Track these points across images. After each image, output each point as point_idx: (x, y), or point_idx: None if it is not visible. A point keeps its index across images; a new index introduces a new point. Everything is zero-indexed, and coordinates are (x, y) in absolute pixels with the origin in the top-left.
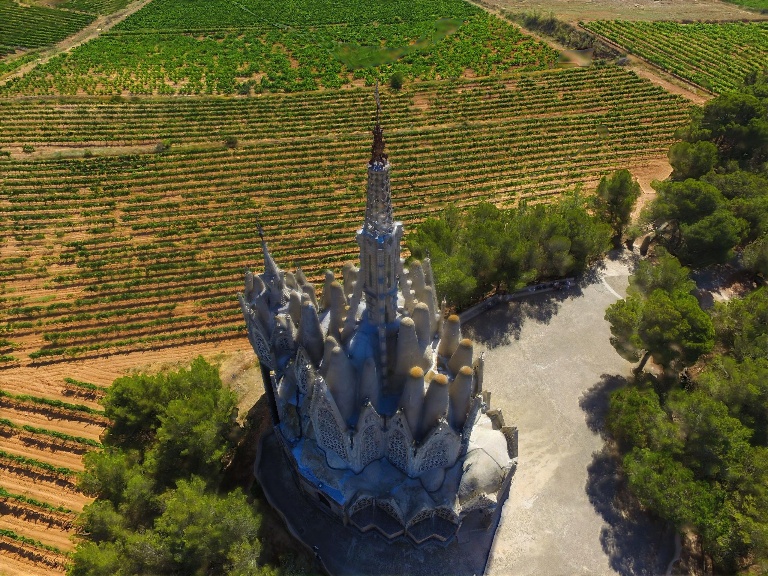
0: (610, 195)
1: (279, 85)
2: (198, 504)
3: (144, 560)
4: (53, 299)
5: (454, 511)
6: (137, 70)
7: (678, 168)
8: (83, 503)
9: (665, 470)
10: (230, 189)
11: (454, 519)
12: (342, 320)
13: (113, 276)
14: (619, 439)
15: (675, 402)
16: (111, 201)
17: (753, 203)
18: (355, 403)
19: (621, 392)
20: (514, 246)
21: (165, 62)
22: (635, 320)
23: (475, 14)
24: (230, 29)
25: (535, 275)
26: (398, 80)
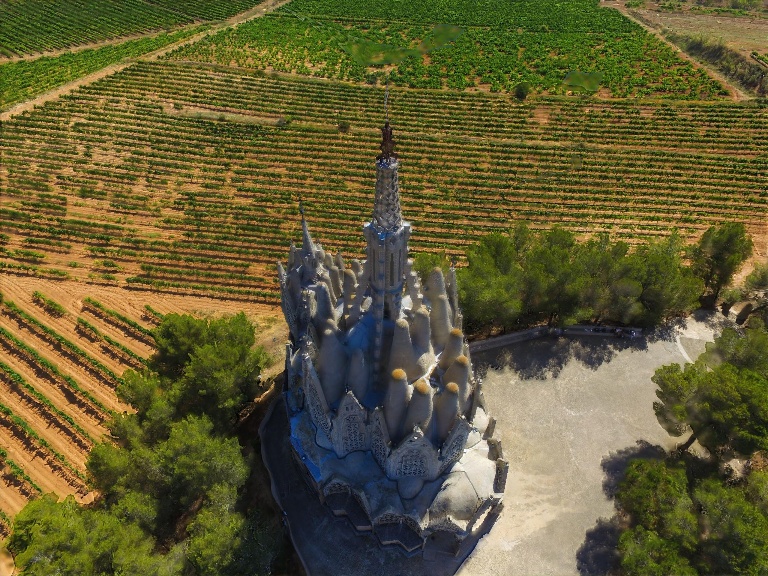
0: (715, 249)
1: (406, 79)
2: (196, 439)
3: (148, 474)
4: (158, 237)
5: (419, 524)
6: (284, 49)
7: None
8: (129, 413)
9: (665, 561)
10: (330, 170)
11: (420, 532)
12: (348, 307)
13: (209, 228)
14: None
15: (705, 492)
16: (227, 162)
17: None
18: (342, 389)
19: (645, 463)
20: (573, 279)
21: (310, 45)
22: (685, 390)
23: (632, 31)
24: (377, 21)
25: (590, 315)
26: (524, 90)
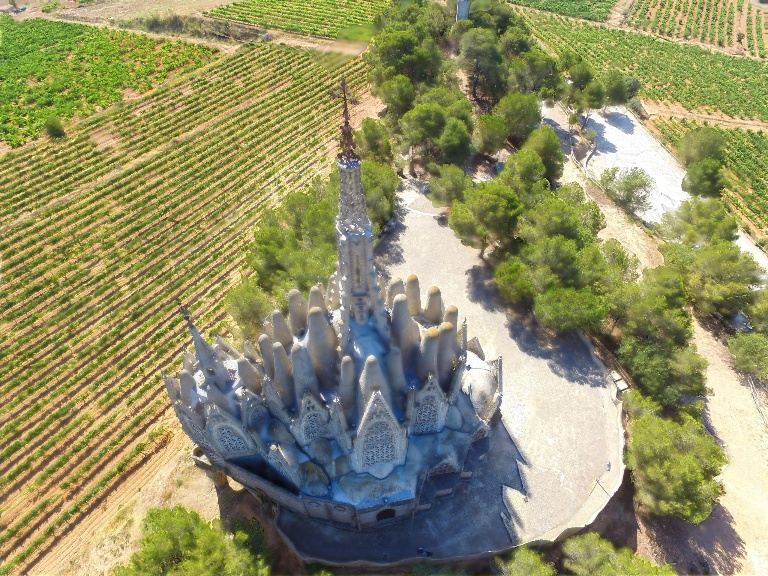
0: (367, 143)
1: None
2: None
3: None
4: None
5: (486, 426)
6: None
7: (393, 103)
8: None
9: (561, 297)
10: None
11: (485, 434)
12: (339, 338)
13: None
14: (509, 305)
15: (531, 254)
16: None
17: (457, 106)
18: (391, 400)
19: None
20: None
21: None
22: (472, 217)
23: (83, 32)
24: None
25: (379, 228)
26: (56, 126)
